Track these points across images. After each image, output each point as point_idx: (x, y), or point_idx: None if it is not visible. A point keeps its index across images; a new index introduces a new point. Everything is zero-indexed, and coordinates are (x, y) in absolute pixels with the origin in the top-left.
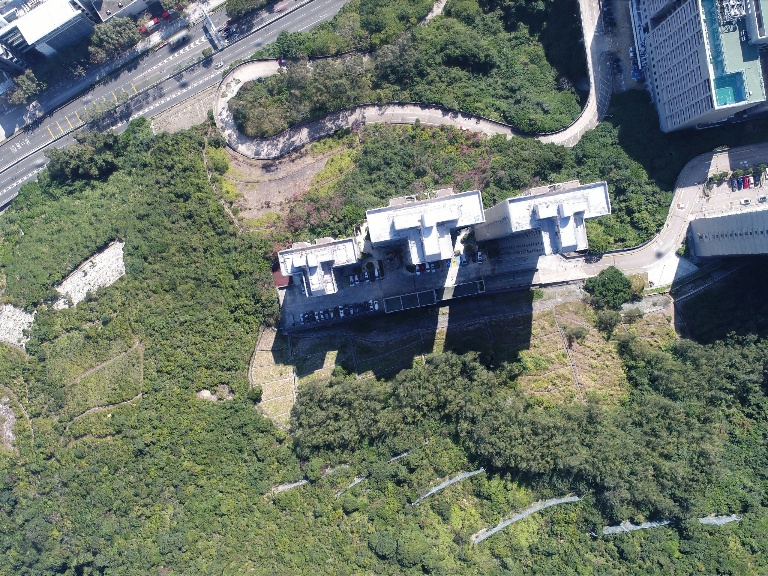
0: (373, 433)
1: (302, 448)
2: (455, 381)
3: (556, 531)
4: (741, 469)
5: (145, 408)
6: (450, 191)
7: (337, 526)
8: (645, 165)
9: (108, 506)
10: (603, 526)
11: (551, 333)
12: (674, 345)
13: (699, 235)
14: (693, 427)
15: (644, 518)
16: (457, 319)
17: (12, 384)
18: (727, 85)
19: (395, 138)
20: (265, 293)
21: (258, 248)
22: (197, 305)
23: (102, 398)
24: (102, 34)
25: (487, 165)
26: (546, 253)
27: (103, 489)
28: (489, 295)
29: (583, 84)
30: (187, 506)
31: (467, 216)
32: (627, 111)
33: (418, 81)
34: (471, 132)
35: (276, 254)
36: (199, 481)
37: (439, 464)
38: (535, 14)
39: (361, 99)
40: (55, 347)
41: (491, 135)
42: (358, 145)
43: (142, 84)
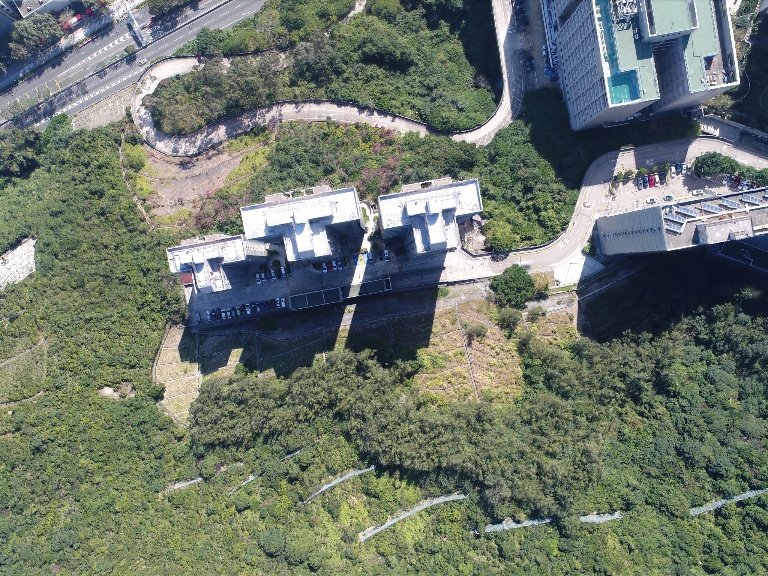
0: (264, 431)
1: (196, 446)
2: (348, 379)
3: (440, 529)
4: (628, 467)
5: (45, 405)
6: (326, 188)
7: (229, 524)
8: (553, 163)
9: (5, 503)
10: (487, 524)
11: (452, 331)
12: (573, 343)
13: (603, 233)
14: (580, 425)
15: (526, 516)
16: (361, 317)
17: None
18: (623, 83)
19: (308, 136)
20: (170, 290)
21: (166, 245)
22: (104, 302)
23: (3, 395)
24: (22, 30)
25: (396, 163)
26: (418, 250)
27: None
28: (397, 293)
29: (501, 82)
30: (81, 503)
31: (343, 213)
32: (538, 109)
33: (334, 79)
34: (385, 130)
35: None
36: (95, 478)
37: (329, 462)
38: (454, 12)
39: (277, 96)
40: None
41: (404, 133)
42: (273, 142)
43: (66, 81)
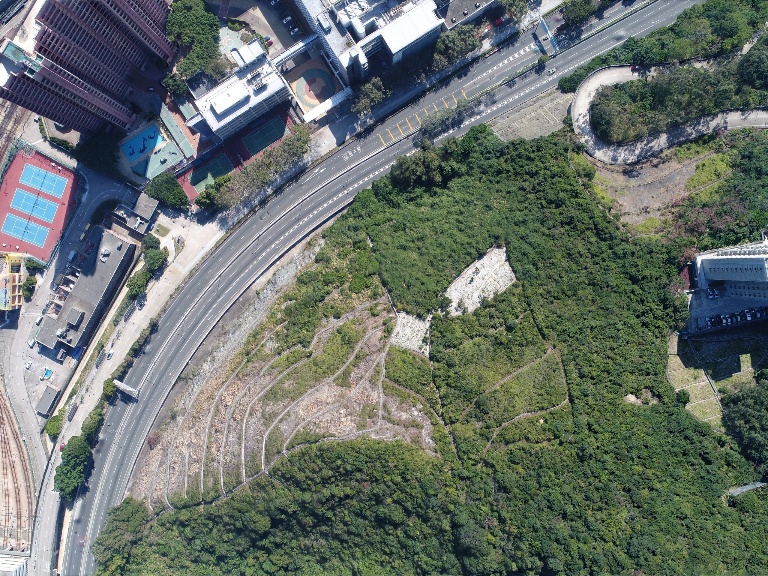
0: None
1: (762, 451)
2: None
3: None
4: None
5: (581, 413)
6: None
7: None
8: None
9: (558, 511)
10: None
11: None
12: None
13: None
14: None
15: None
16: None
17: (424, 391)
18: None
19: None
20: (678, 298)
21: (659, 253)
22: (600, 310)
23: (531, 404)
24: (450, 42)
25: None
26: None
27: (553, 494)
28: None
29: None
30: (648, 510)
31: None
32: None
33: None
34: None
35: (688, 259)
36: (654, 485)
37: None
38: None
39: (727, 104)
40: (463, 354)
41: None
42: (728, 150)
43: (472, 91)
